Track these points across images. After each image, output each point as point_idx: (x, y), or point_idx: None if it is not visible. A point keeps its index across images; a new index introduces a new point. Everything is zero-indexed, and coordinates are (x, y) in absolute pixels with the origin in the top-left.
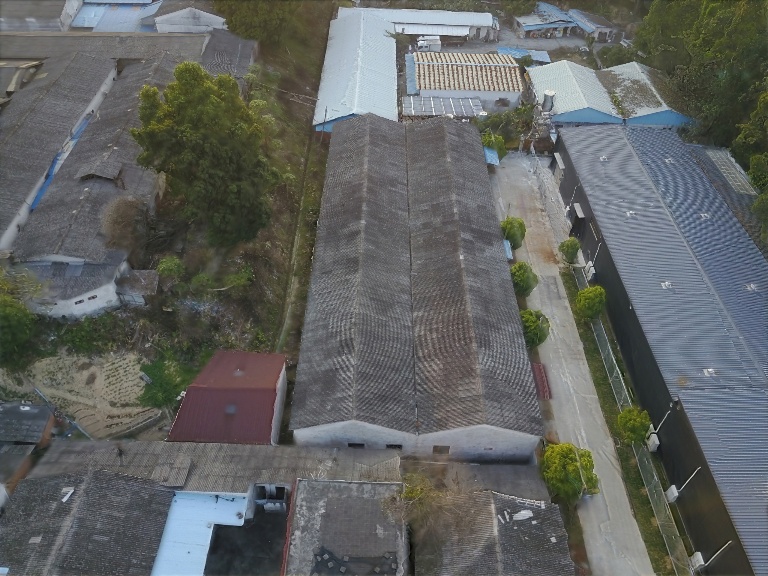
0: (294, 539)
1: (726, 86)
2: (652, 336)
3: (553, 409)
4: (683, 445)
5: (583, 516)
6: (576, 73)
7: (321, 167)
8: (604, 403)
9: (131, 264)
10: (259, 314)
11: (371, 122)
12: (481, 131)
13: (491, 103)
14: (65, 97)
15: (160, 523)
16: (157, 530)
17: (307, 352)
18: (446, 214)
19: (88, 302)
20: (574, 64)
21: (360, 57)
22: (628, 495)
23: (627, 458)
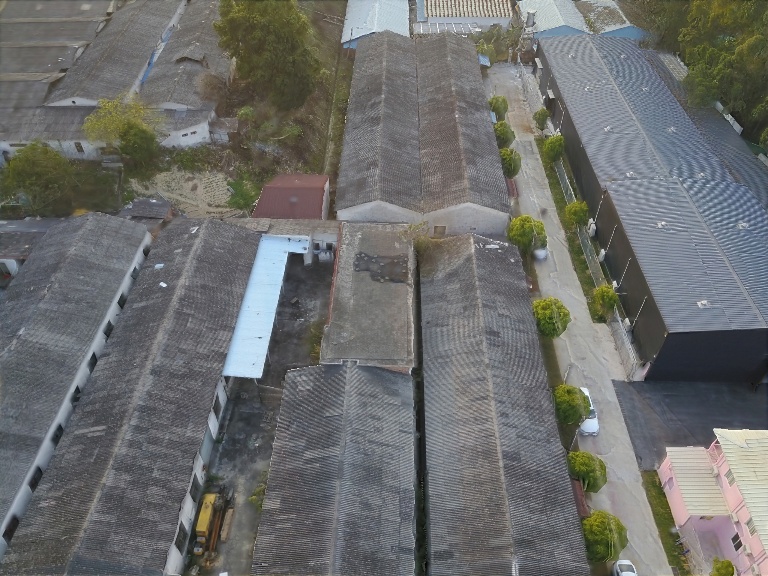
0: (342, 248)
1: (674, 1)
2: (593, 157)
3: None
4: (608, 219)
5: (539, 269)
6: (557, 2)
7: (349, 73)
8: (560, 212)
9: (217, 115)
10: (307, 158)
11: (388, 36)
12: (476, 43)
13: (487, 28)
14: (153, 14)
15: (254, 249)
16: (253, 251)
17: (344, 171)
18: (446, 92)
19: (190, 136)
20: None
21: None
22: (572, 259)
23: (573, 241)
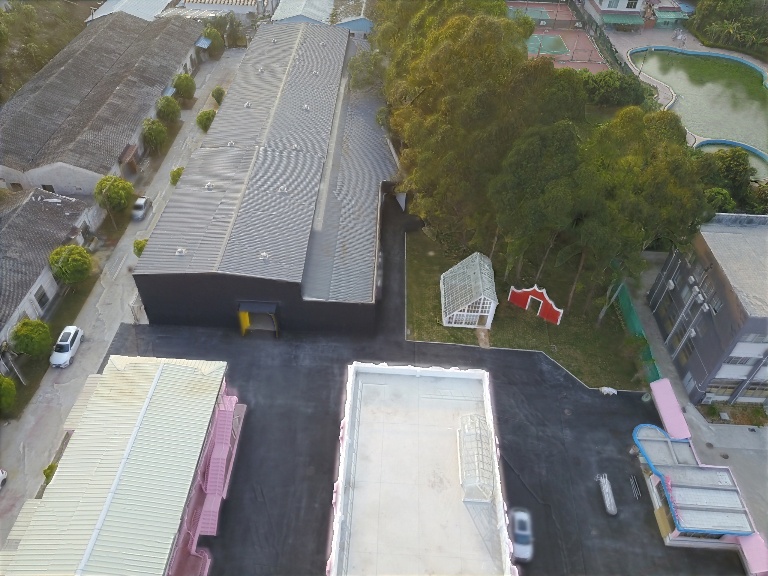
0: None
1: None
2: (212, 128)
3: (153, 181)
4: None
5: (130, 228)
6: None
7: None
8: None
9: None
10: None
11: (117, 16)
12: None
13: (244, 16)
14: None
15: None
16: None
17: None
18: (129, 67)
19: None
20: None
21: None
22: None
23: None
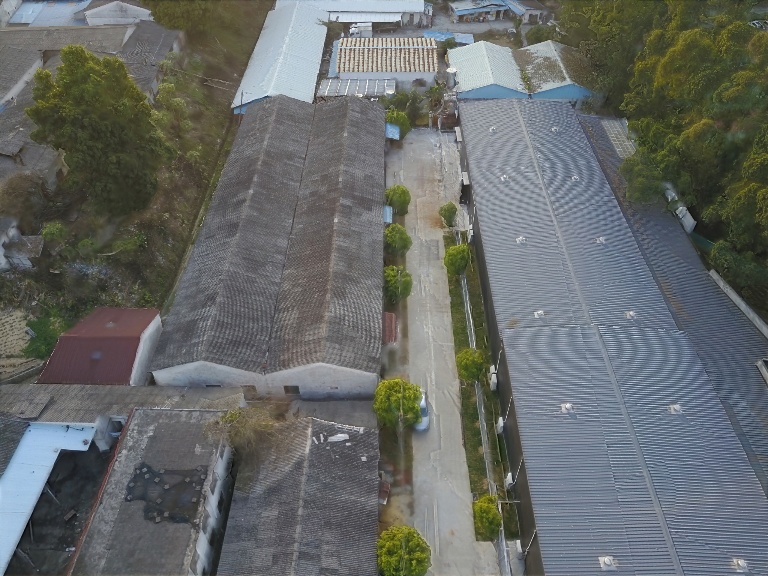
0: (120, 456)
1: (617, 58)
2: (495, 285)
3: (410, 356)
4: (506, 379)
5: (417, 446)
6: (490, 52)
7: None
8: (459, 350)
9: (22, 231)
10: (147, 277)
11: (280, 103)
12: (387, 108)
13: (409, 84)
14: None
15: (11, 448)
16: (7, 453)
17: (177, 306)
18: (331, 183)
19: None
20: (491, 44)
21: (286, 44)
22: (462, 428)
23: (469, 396)
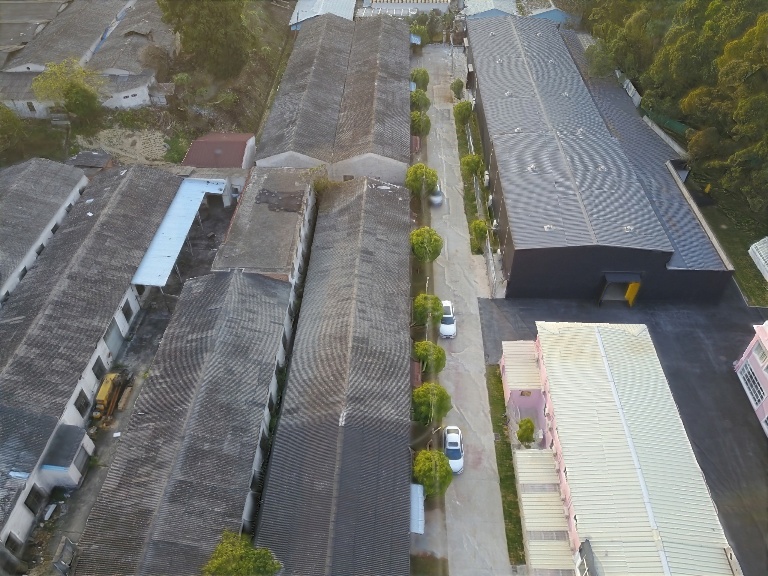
0: (248, 186)
1: None
2: (489, 117)
3: None
4: None
5: (433, 213)
6: None
7: None
8: None
9: (158, 81)
10: (241, 121)
11: (329, 18)
12: (411, 24)
13: (427, 13)
14: None
15: (175, 189)
16: (173, 191)
17: (268, 129)
18: (371, 65)
19: (131, 98)
20: None
21: None
22: (464, 204)
23: (469, 190)
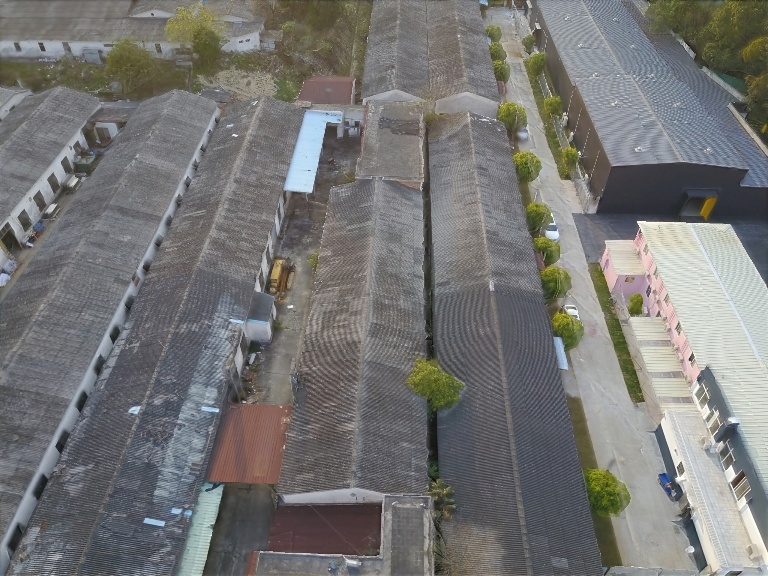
0: (369, 115)
1: None
2: (567, 64)
3: None
4: (576, 107)
5: (521, 147)
6: None
7: (368, 11)
8: (541, 111)
9: (265, 29)
10: (337, 68)
11: None
12: None
13: None
14: None
15: (301, 118)
16: (300, 120)
17: (368, 73)
18: (450, 20)
19: (245, 43)
20: None
21: None
22: (547, 141)
23: (550, 129)
